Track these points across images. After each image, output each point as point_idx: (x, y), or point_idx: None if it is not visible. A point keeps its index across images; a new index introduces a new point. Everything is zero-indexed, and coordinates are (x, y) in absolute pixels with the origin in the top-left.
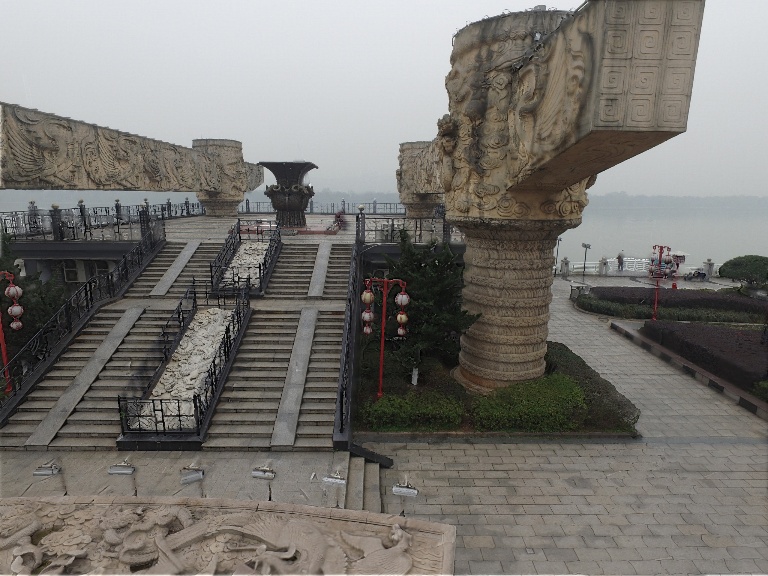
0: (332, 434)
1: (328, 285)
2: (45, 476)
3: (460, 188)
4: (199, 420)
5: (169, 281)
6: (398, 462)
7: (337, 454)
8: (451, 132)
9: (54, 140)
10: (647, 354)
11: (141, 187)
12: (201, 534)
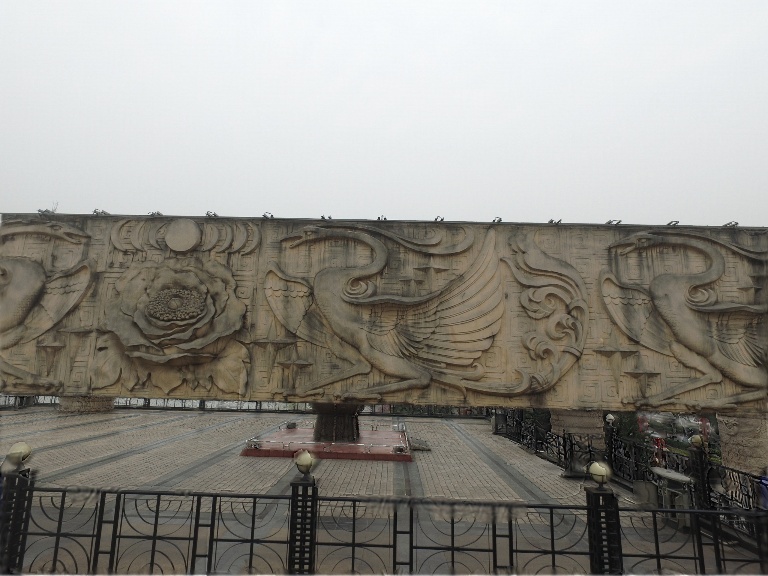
0: None
1: None
2: None
3: None
4: None
5: None
6: None
7: None
8: None
9: None
10: None
11: None
12: None
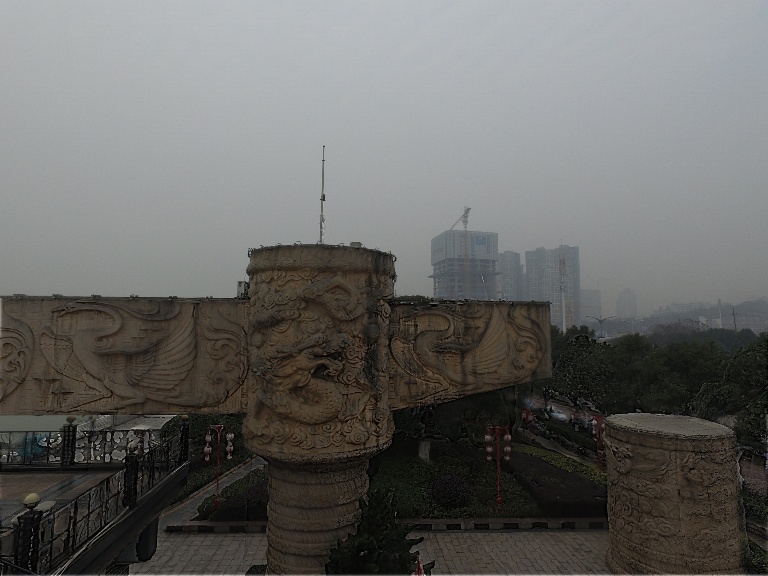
0: None
1: None
2: None
3: (356, 417)
4: None
5: None
6: None
7: None
8: None
9: None
10: (251, 535)
11: None
12: None
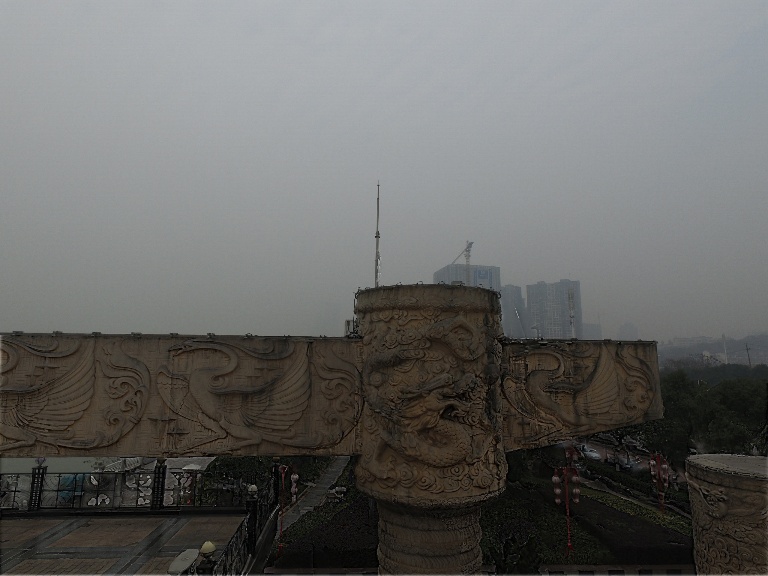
0: None
1: None
2: None
3: None
4: None
5: None
6: None
7: None
8: None
9: None
10: None
11: None
12: None
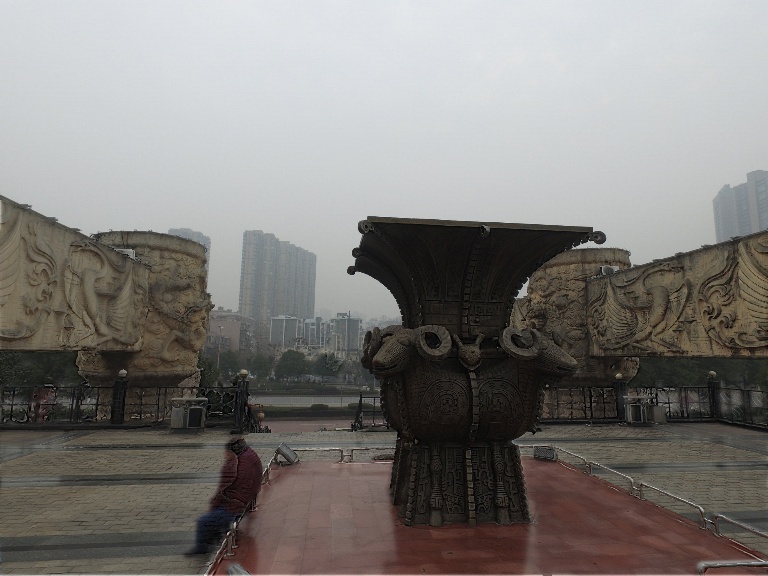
0: None
1: None
2: None
3: None
4: None
5: None
6: None
7: None
8: None
9: None
10: None
11: None
12: None
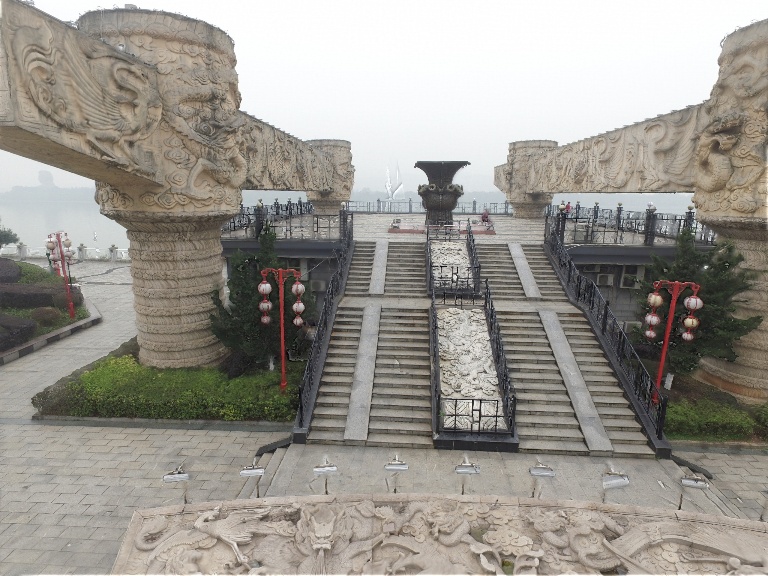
0: (646, 441)
1: (541, 286)
2: (391, 472)
3: (743, 187)
4: (506, 421)
5: (381, 280)
6: (715, 473)
7: (662, 462)
8: (729, 129)
9: (254, 141)
10: None
11: (294, 187)
12: (647, 542)
